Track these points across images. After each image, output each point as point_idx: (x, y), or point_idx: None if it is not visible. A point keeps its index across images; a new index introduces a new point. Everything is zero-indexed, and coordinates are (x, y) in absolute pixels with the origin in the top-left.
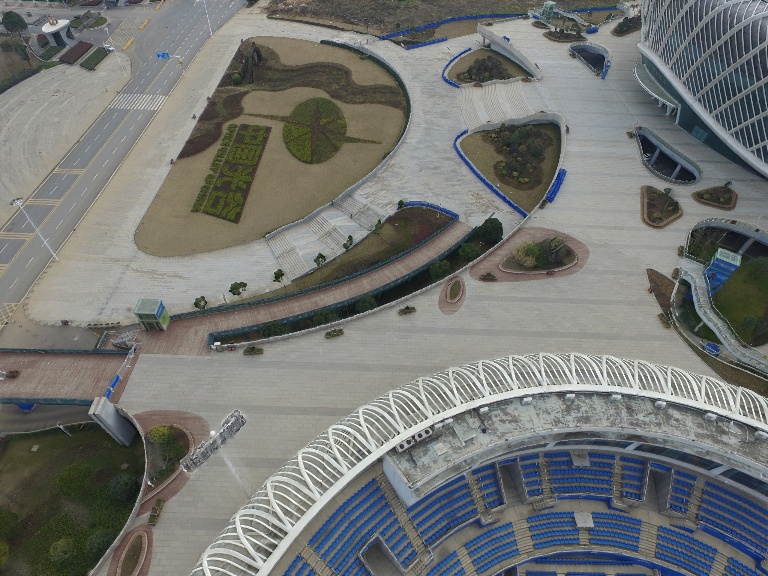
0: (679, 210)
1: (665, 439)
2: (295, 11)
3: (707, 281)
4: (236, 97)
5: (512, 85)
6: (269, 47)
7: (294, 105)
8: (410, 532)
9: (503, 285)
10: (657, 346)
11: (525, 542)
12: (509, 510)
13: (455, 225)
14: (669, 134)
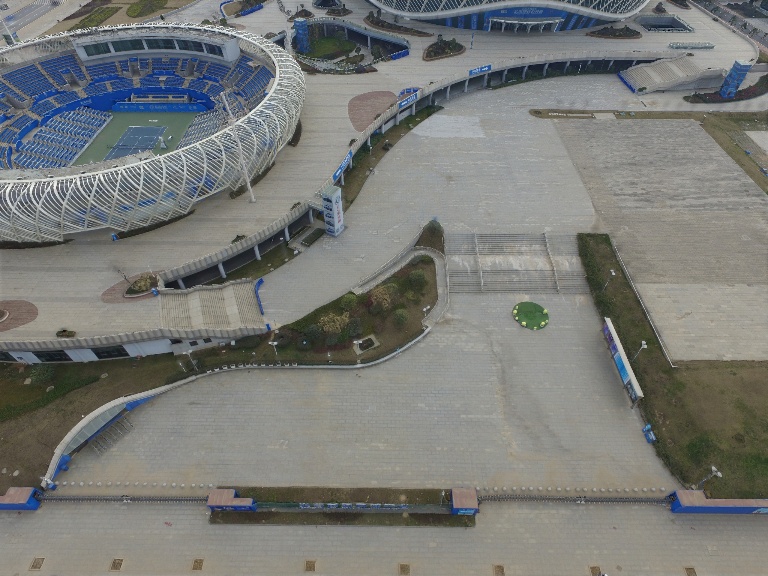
0: (310, 16)
1: None
2: None
3: (292, 33)
4: None
5: None
6: None
7: None
8: (86, 74)
9: None
10: None
11: (137, 86)
12: (134, 77)
13: None
14: None
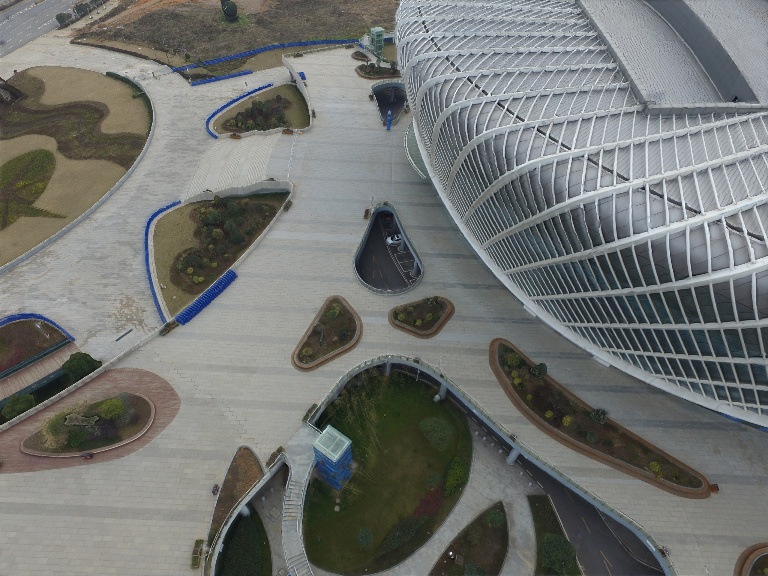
0: (352, 339)
1: None
2: (107, 34)
3: (306, 475)
4: None
5: (269, 138)
6: (42, 80)
7: (6, 160)
8: None
9: (2, 479)
10: None
11: None
12: None
13: (60, 352)
14: (421, 212)
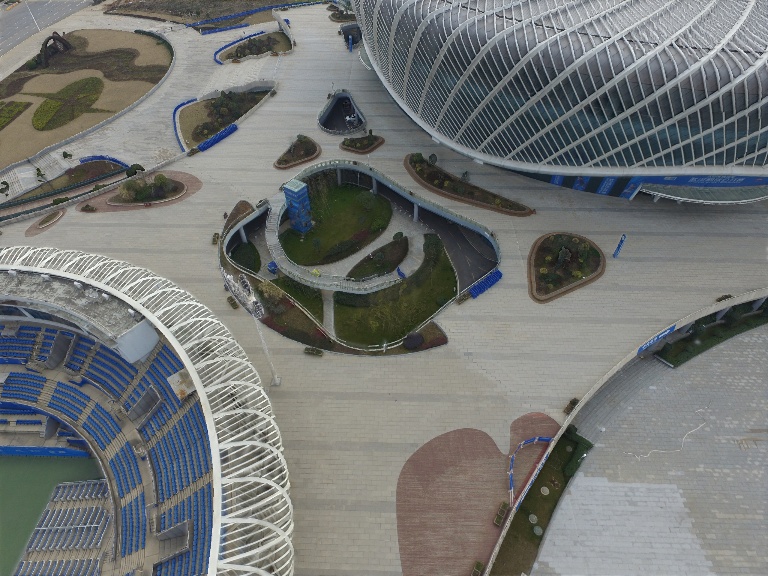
0: (313, 154)
1: (33, 303)
2: (132, 7)
3: (280, 208)
4: (22, 80)
5: (261, 59)
6: (85, 38)
7: (67, 84)
8: None
9: (98, 214)
10: (191, 258)
11: None
12: None
13: (122, 174)
14: (369, 95)
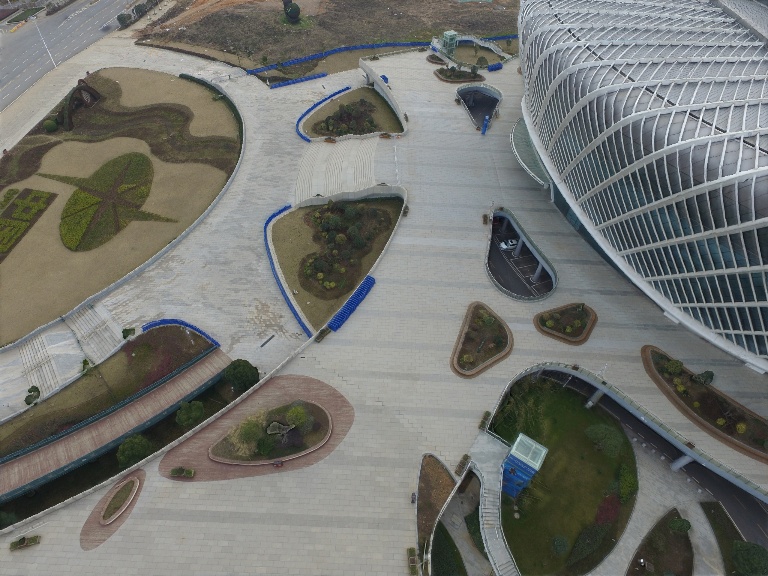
0: (506, 346)
1: None
2: (170, 35)
3: (500, 483)
4: (39, 150)
5: (367, 142)
6: (117, 82)
7: (102, 163)
8: None
9: (199, 487)
10: None
11: None
12: None
13: (209, 358)
14: (538, 217)
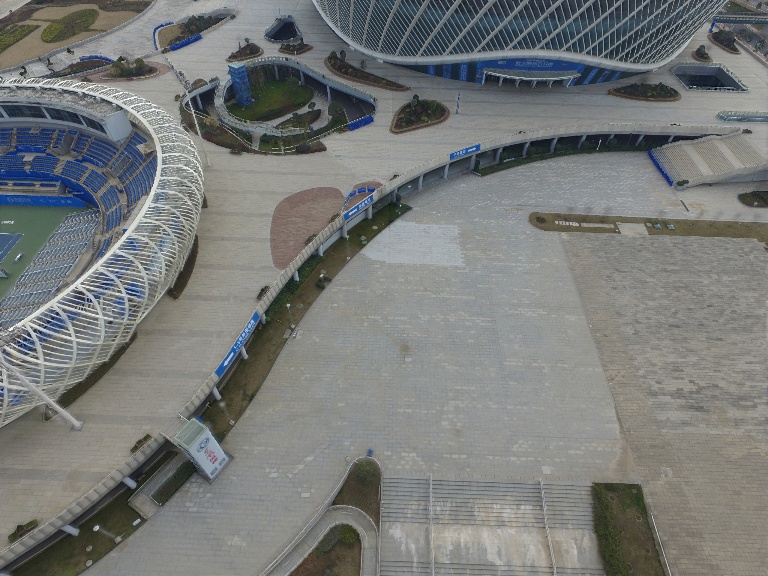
0: (257, 54)
1: None
2: None
3: (226, 82)
4: (31, 10)
5: None
6: None
7: (69, 13)
8: None
9: None
10: None
11: None
12: None
13: None
14: (308, 20)
